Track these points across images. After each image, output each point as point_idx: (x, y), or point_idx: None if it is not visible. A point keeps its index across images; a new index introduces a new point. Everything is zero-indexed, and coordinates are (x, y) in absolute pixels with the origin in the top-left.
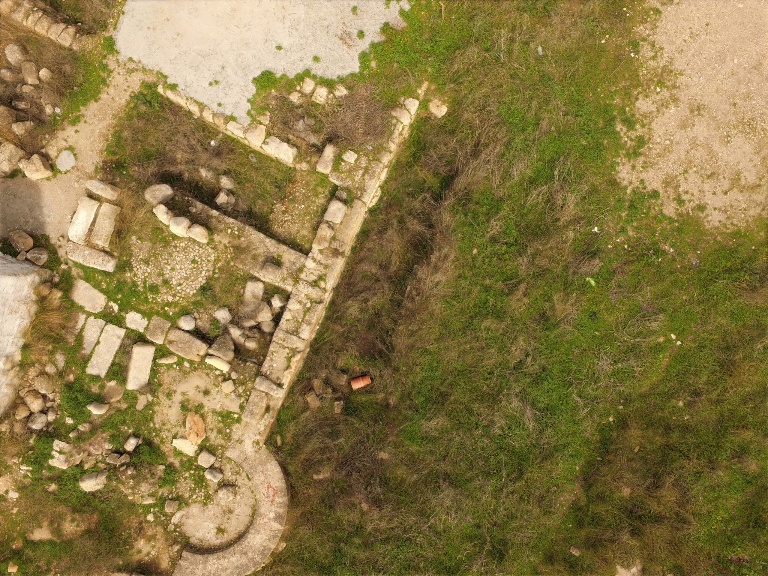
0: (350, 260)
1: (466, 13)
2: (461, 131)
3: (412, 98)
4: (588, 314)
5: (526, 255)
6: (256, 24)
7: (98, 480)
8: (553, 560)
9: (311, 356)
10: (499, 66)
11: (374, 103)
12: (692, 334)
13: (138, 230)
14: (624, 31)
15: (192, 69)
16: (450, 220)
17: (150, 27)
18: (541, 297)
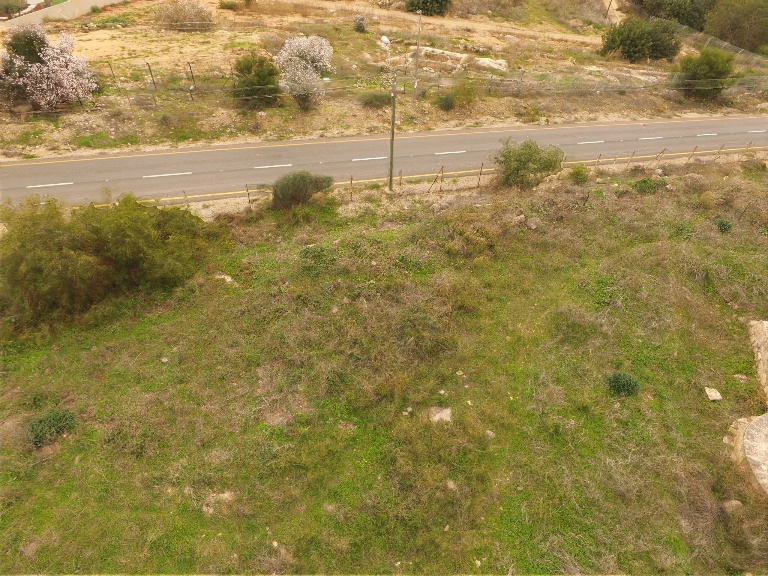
0: None
1: None
2: None
3: None
4: None
5: None
6: None
7: None
8: (506, 427)
9: None
10: None
11: None
12: None
13: None
14: None
15: None
16: None
17: None
18: None
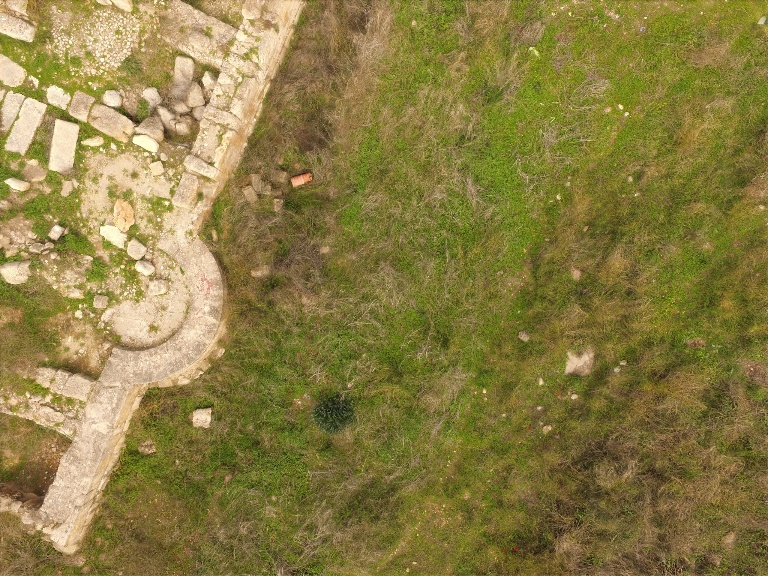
0: (289, 53)
1: None
2: None
3: None
4: (532, 84)
5: (465, 18)
6: None
7: (20, 268)
8: (501, 348)
9: (248, 151)
10: None
11: None
12: (640, 103)
13: None
14: None
15: None
16: None
17: None
18: (483, 68)
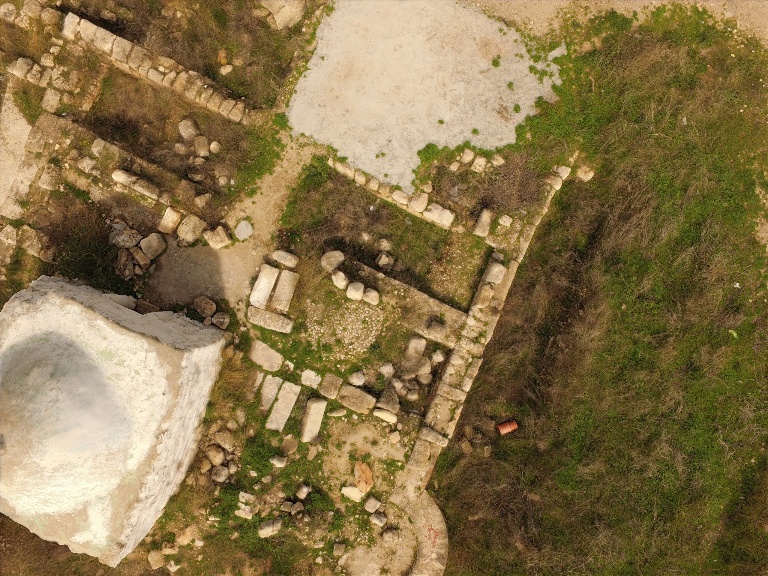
0: None
1: (617, 88)
2: (612, 196)
3: (565, 166)
4: (732, 364)
5: (676, 311)
6: (420, 100)
7: (275, 527)
8: None
9: None
10: (647, 136)
11: (529, 171)
12: None
13: (312, 294)
14: (761, 101)
15: (361, 143)
16: (603, 279)
17: (321, 104)
18: (687, 349)
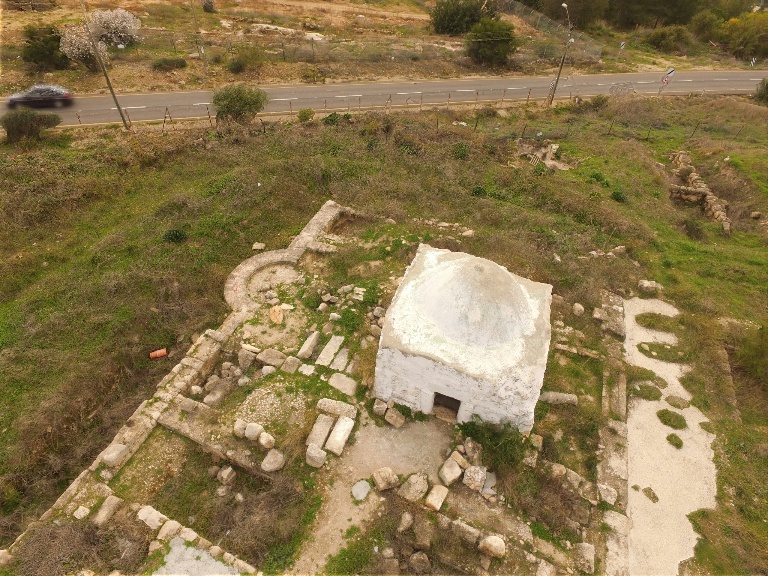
0: None
1: None
2: None
3: None
4: None
5: None
6: None
7: (342, 288)
8: (63, 261)
9: None
10: None
11: (26, 572)
12: None
13: None
14: None
15: None
16: None
17: None
18: None
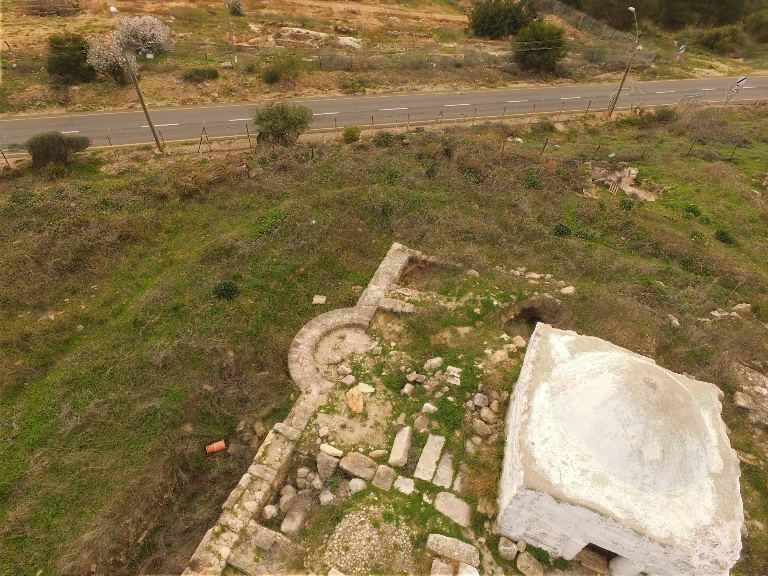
0: None
1: None
2: None
3: None
4: None
5: None
6: None
7: (429, 363)
8: (100, 323)
9: None
10: None
11: None
12: None
13: None
14: None
15: None
16: None
17: None
18: None
